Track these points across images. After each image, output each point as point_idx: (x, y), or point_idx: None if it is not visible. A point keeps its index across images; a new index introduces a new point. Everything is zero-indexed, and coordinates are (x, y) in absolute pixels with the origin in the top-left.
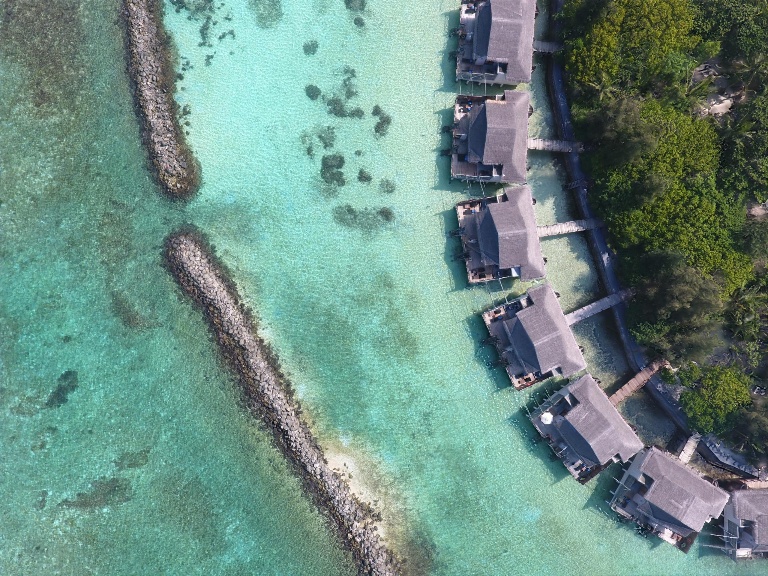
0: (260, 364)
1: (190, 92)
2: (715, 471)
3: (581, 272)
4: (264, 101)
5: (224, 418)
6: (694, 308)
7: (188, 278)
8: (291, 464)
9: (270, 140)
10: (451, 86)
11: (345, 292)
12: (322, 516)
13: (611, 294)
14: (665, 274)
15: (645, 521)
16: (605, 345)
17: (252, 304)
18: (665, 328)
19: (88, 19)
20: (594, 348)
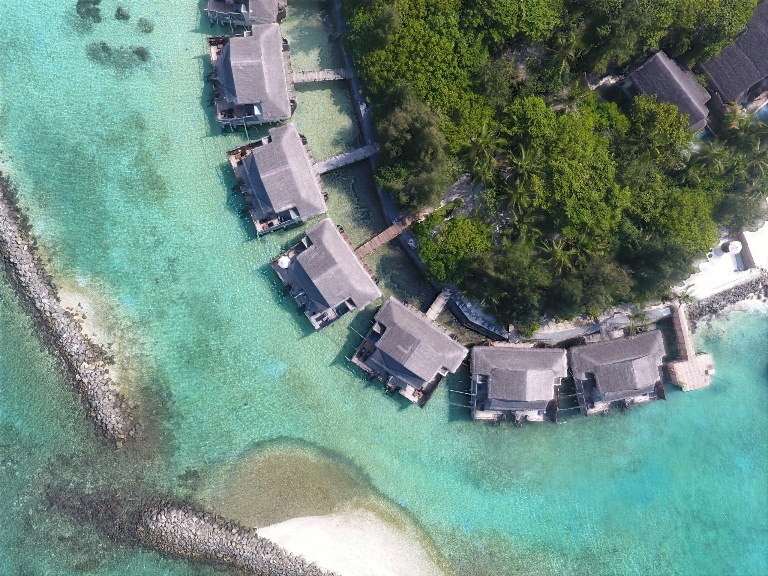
0: None
1: None
2: (469, 334)
3: (343, 125)
4: None
5: None
6: (418, 142)
7: None
8: (23, 301)
9: None
10: None
11: (94, 130)
12: (52, 356)
13: None
14: None
15: (386, 376)
16: (363, 200)
17: None
18: (401, 170)
19: None
20: (351, 203)
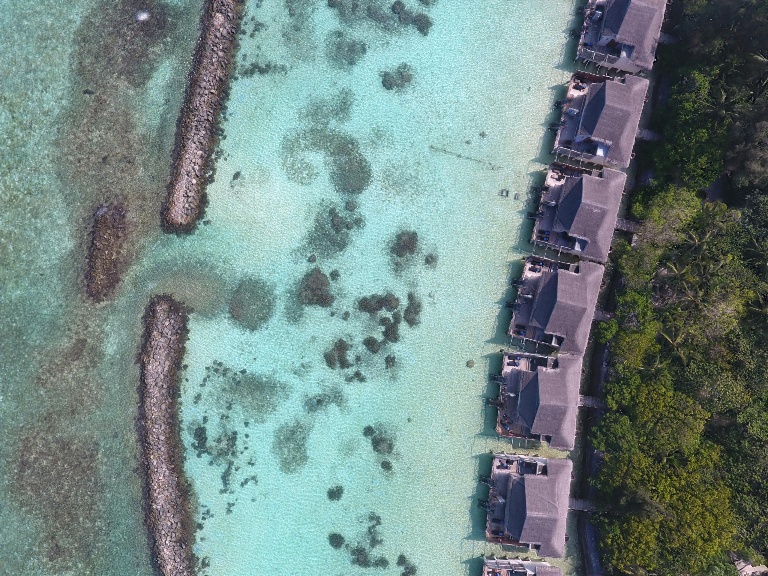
0: None
1: (210, 543)
2: None
3: None
4: (286, 551)
5: None
6: None
7: None
8: None
9: None
10: (479, 534)
11: None
12: None
13: None
14: None
15: None
16: None
17: None
18: None
19: (106, 466)
20: None
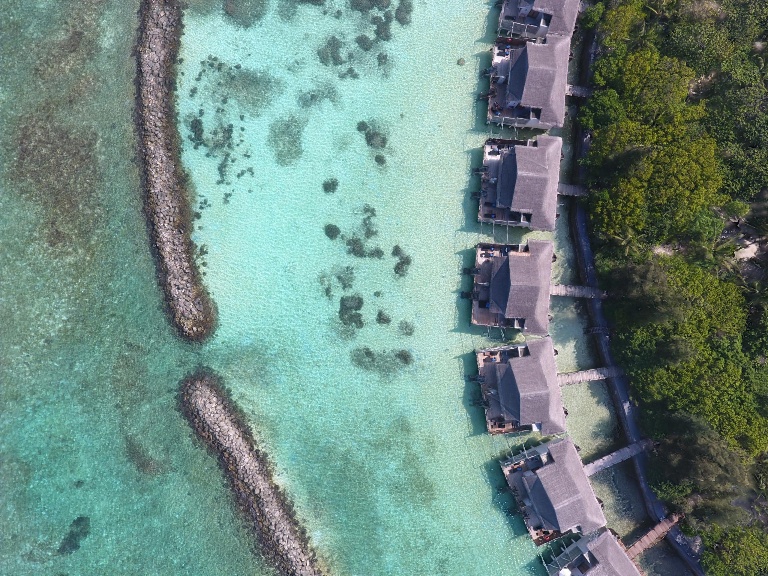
0: (275, 514)
1: (207, 231)
2: None
3: (601, 417)
4: (282, 241)
5: (238, 565)
6: (718, 479)
7: (203, 425)
8: None
9: (288, 281)
10: (472, 226)
11: (362, 437)
12: None
13: (632, 444)
14: (689, 437)
15: None
16: (624, 492)
17: (268, 449)
18: (687, 490)
19: (105, 156)
20: (613, 495)
